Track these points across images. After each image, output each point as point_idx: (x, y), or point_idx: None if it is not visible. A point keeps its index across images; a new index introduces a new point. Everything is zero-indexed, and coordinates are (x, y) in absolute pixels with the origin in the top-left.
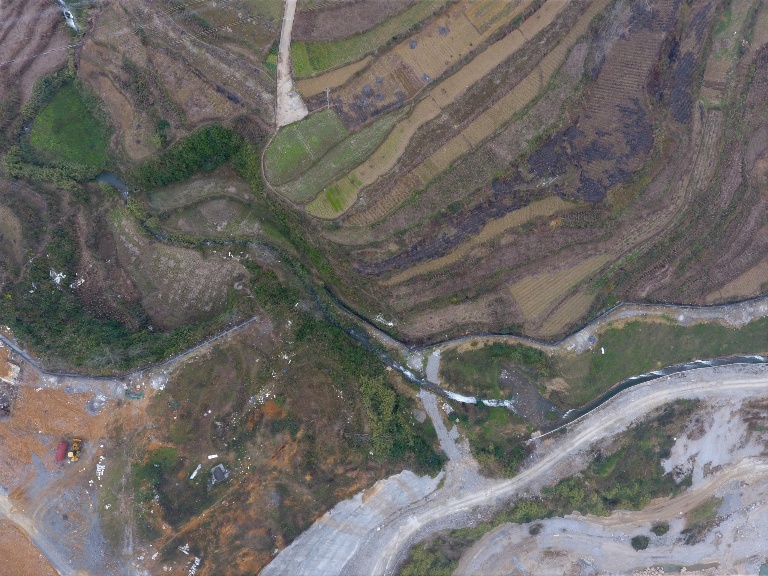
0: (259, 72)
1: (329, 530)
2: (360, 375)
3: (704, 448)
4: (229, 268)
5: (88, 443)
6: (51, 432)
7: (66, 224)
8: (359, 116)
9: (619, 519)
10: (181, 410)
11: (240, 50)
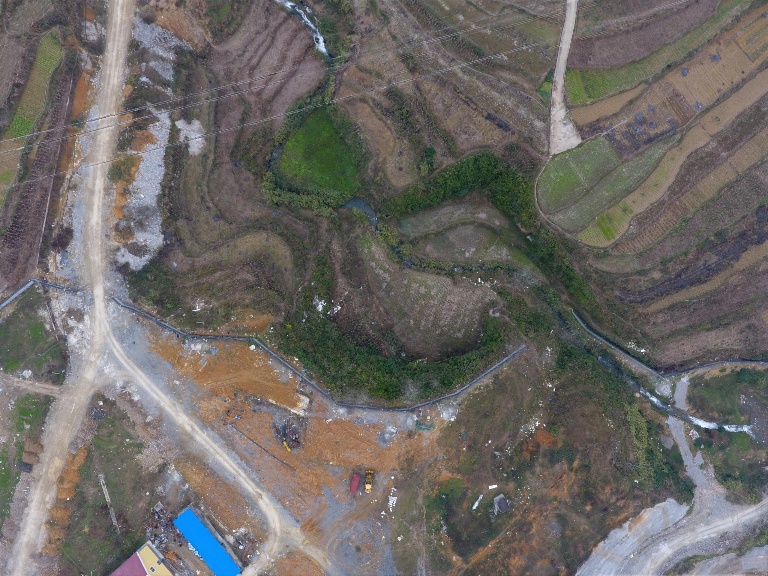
0: (531, 100)
1: (597, 559)
2: (623, 403)
3: None
4: (480, 294)
5: (379, 474)
6: (342, 463)
7: (325, 251)
8: (632, 144)
9: None
10: (469, 441)
11: (514, 78)
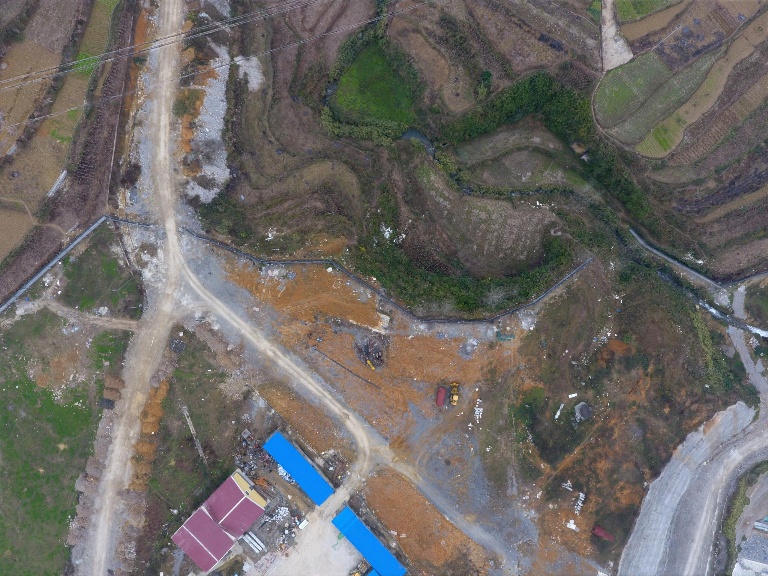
0: (581, 19)
1: (675, 464)
2: (689, 311)
3: None
4: (540, 216)
5: (464, 387)
6: (427, 378)
7: (388, 180)
8: (681, 57)
9: None
10: (548, 349)
11: None
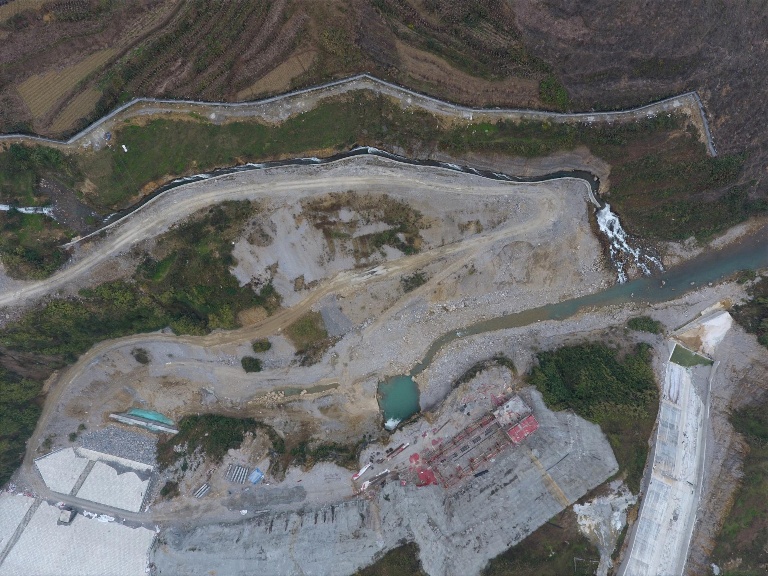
0: None
1: None
2: None
3: (282, 258)
4: None
5: None
6: None
7: None
8: None
9: (219, 339)
10: None
11: None
